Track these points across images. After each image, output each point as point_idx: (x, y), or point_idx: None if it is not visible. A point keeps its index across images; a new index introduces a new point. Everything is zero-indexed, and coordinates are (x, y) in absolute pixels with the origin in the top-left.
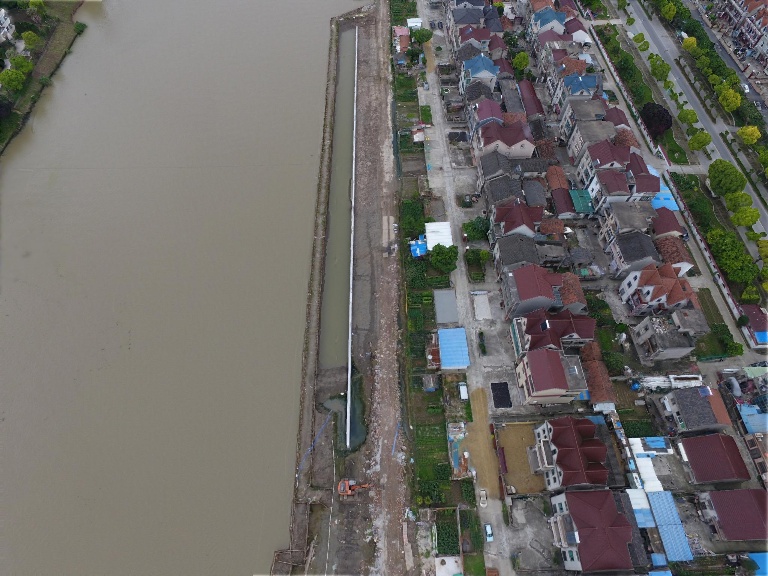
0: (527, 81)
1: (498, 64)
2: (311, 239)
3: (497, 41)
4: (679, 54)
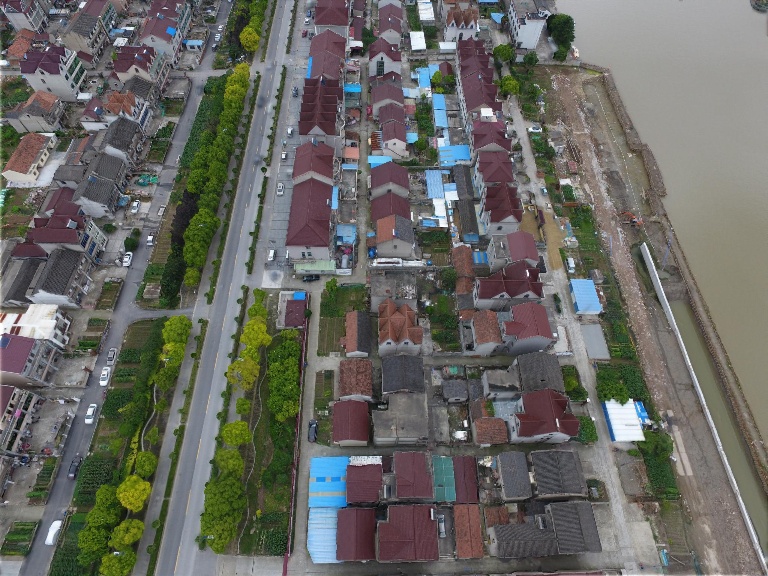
0: None
1: None
2: (765, 439)
3: None
4: None
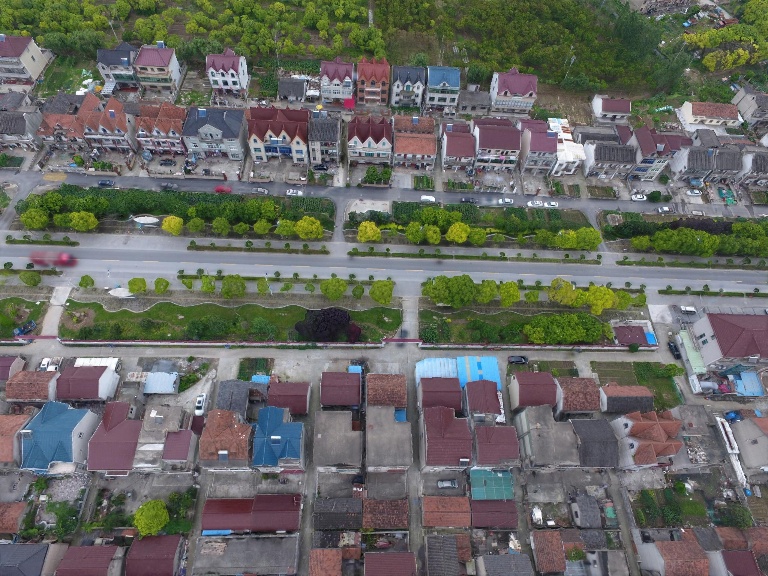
0: (206, 513)
1: (142, 570)
2: None
3: (85, 571)
4: (175, 238)
